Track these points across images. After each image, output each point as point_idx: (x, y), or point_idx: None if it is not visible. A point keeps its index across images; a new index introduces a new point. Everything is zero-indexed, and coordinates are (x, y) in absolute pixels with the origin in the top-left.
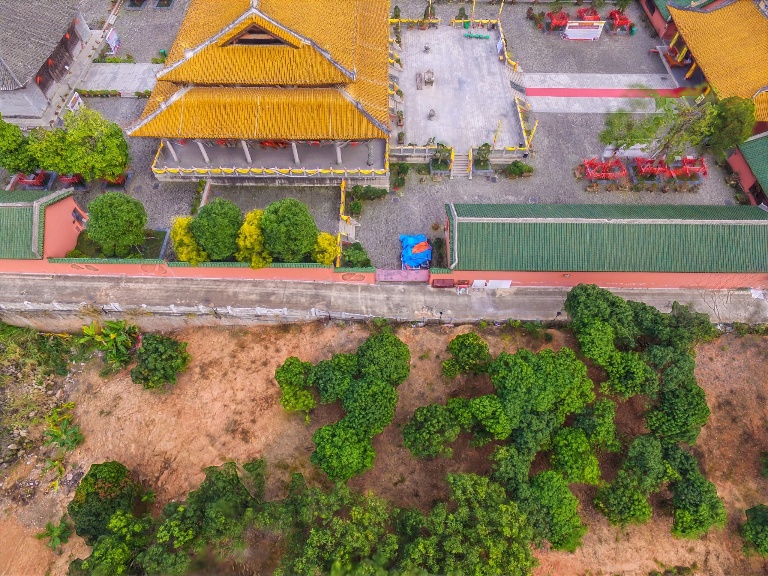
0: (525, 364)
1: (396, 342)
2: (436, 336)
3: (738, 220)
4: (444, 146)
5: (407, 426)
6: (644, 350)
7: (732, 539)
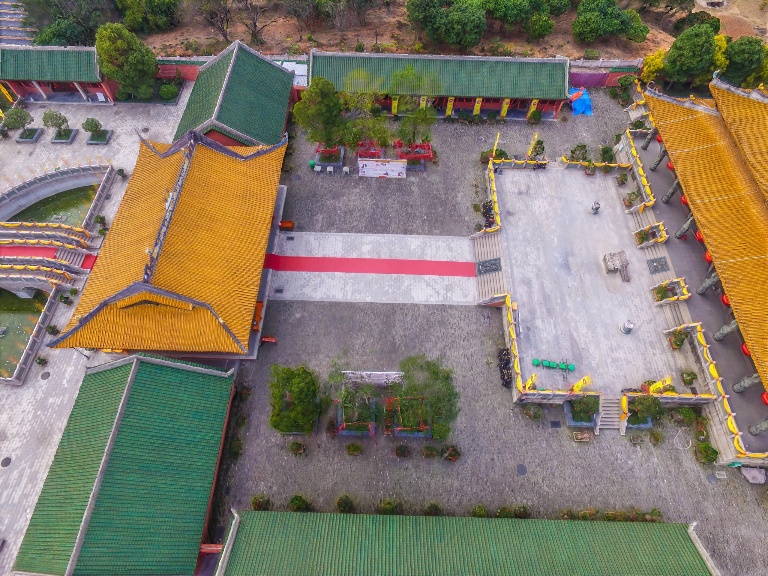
0: (516, 1)
1: (586, 28)
2: (554, 54)
3: (353, 53)
4: (580, 148)
5: (569, 6)
6: (449, 0)
7: (394, 11)
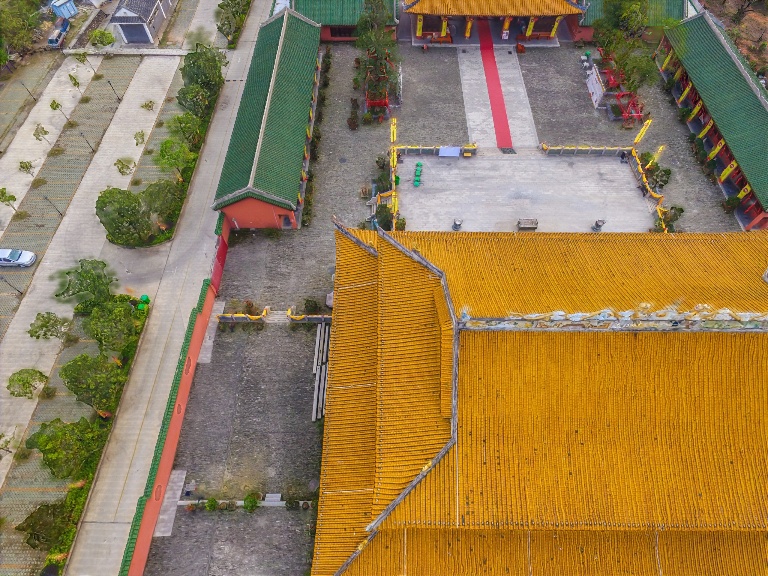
0: None
1: None
2: None
3: None
4: (678, 208)
5: None
6: None
7: None
